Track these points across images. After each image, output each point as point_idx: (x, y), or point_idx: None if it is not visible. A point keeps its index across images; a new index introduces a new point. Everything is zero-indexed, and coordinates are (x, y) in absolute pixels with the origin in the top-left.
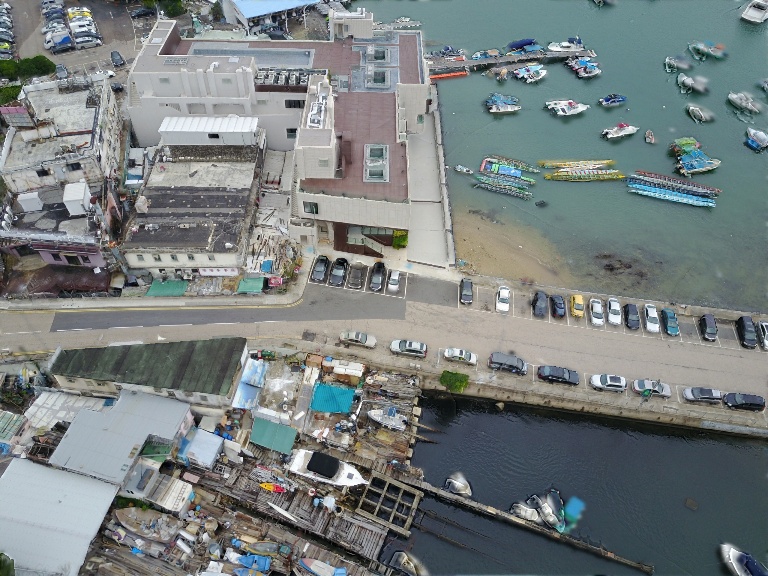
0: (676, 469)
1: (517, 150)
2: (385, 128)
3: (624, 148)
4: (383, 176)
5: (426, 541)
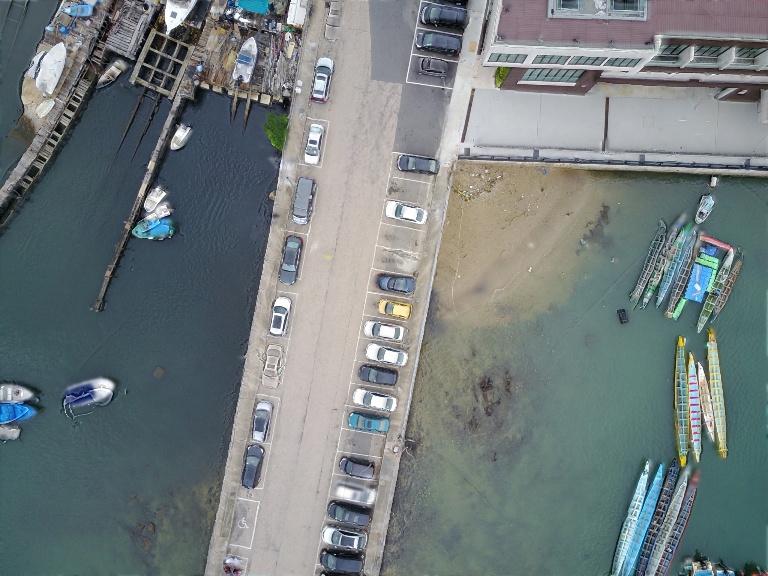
0: (202, 373)
1: (761, 308)
2: (698, 18)
3: (765, 492)
4: (561, 8)
5: (128, 100)
